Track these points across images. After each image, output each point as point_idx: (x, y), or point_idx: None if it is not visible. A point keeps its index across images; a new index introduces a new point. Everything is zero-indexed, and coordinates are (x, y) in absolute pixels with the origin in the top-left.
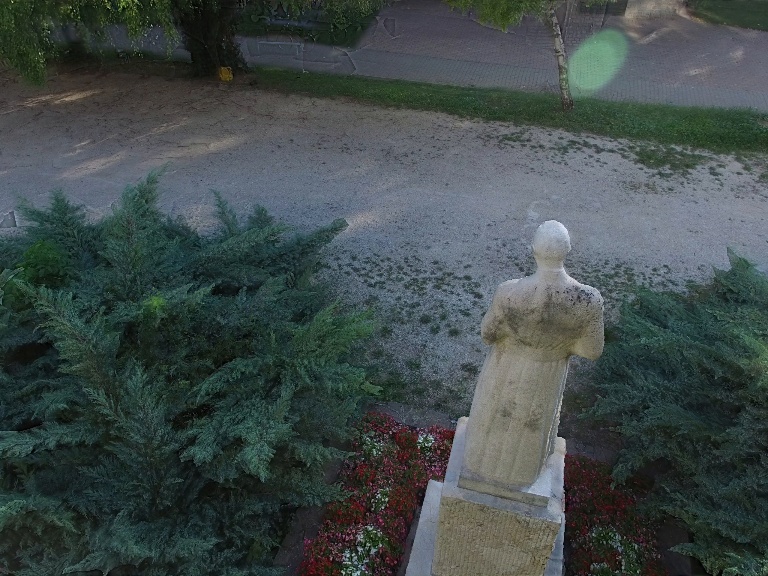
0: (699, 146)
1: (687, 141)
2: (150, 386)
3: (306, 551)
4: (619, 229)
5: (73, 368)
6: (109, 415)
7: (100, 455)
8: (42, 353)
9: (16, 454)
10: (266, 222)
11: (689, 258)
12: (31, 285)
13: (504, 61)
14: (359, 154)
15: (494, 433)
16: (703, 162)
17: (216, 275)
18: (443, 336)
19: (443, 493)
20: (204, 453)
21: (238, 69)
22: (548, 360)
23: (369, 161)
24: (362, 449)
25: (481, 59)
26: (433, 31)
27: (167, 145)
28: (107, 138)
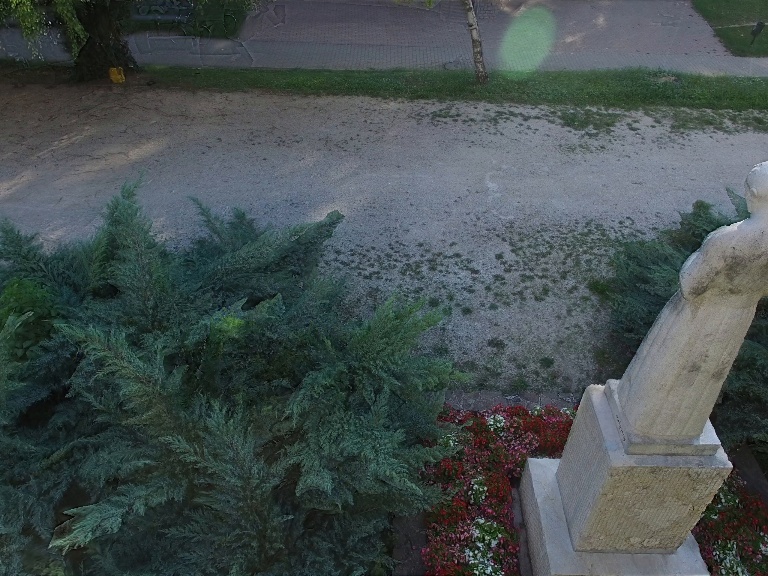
0: (610, 105)
1: (599, 102)
2: (233, 420)
3: (429, 560)
4: (574, 189)
5: (144, 417)
6: (198, 462)
7: (185, 511)
8: (50, 411)
9: (108, 531)
10: (250, 226)
11: (645, 208)
12: (76, 328)
13: (394, 42)
14: (298, 146)
15: (676, 391)
16: (619, 119)
17: (234, 288)
18: (458, 316)
19: (614, 464)
20: (327, 480)
21: (128, 69)
22: (749, 305)
23: (311, 152)
24: (437, 443)
25: (371, 42)
26: (313, 17)
27: (78, 159)
28: (1, 159)
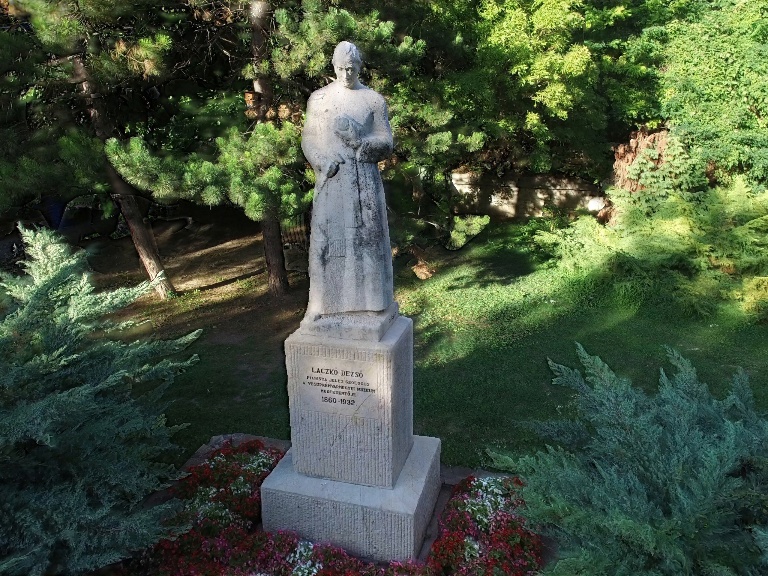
0: None
1: None
2: None
3: None
4: None
5: None
6: None
7: None
8: None
9: None
10: None
11: None
12: None
13: None
14: None
15: None
16: None
17: None
18: None
19: None
20: (667, 393)
21: None
22: None
23: None
24: None
25: None
26: None
27: None
28: None
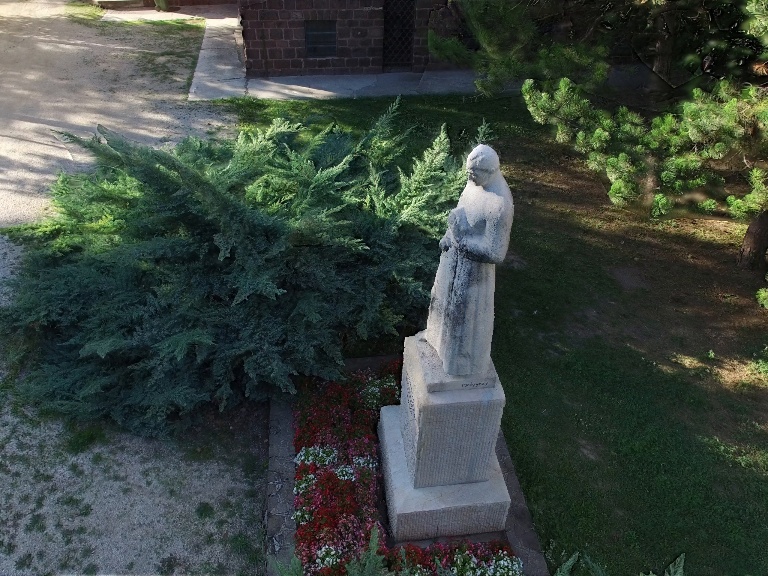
0: None
1: None
2: None
3: None
4: None
5: None
6: None
7: None
8: None
9: None
10: None
11: None
12: None
13: None
14: None
15: None
16: None
17: None
18: None
19: None
20: None
21: None
22: None
23: None
24: None
25: None
26: None
27: None
28: None
